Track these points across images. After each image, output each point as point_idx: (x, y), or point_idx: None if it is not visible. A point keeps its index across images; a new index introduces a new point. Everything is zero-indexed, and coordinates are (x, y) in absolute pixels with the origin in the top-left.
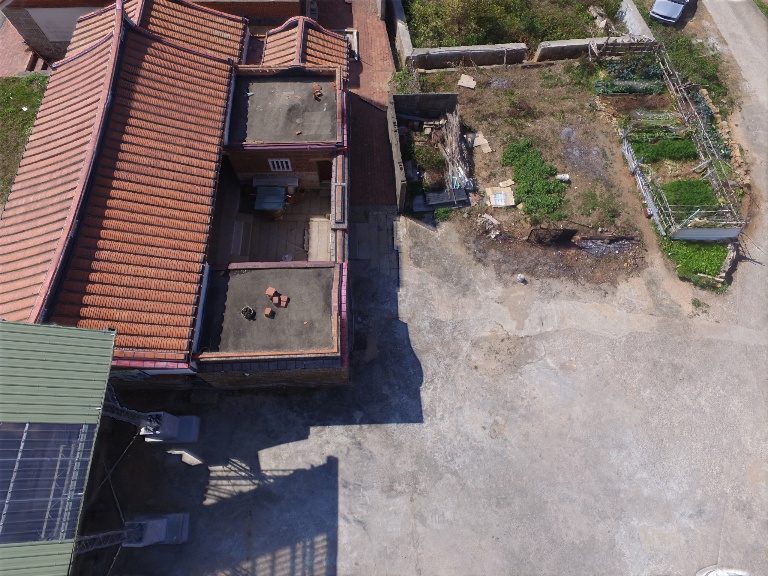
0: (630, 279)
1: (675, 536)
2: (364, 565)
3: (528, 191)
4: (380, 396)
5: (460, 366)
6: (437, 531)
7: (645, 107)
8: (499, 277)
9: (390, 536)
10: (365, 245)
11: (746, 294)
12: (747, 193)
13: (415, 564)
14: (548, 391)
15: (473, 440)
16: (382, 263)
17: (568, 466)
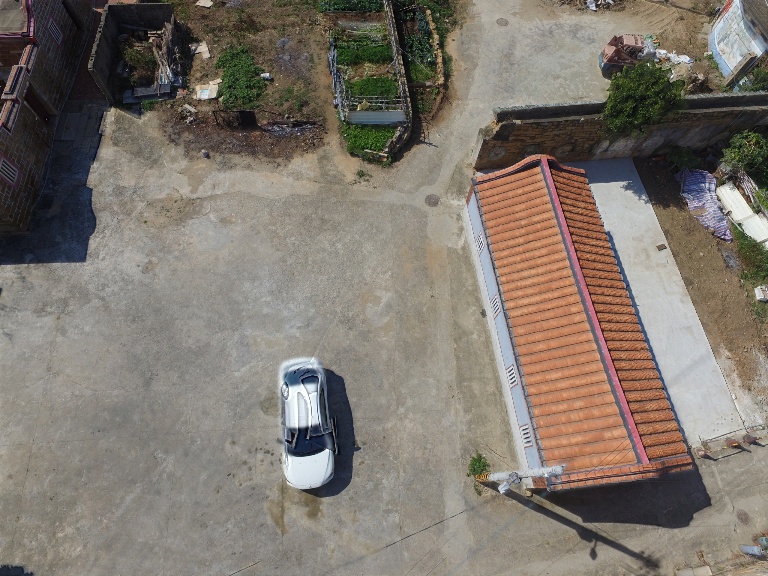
0: (305, 155)
1: (280, 342)
2: (2, 365)
3: (229, 86)
4: (52, 243)
5: (131, 221)
6: (73, 340)
7: (362, 22)
8: (186, 153)
9: (31, 344)
10: (72, 130)
11: (410, 168)
12: (442, 92)
13: (47, 364)
14: (204, 239)
15: (126, 275)
16: (84, 143)
17: (204, 293)
